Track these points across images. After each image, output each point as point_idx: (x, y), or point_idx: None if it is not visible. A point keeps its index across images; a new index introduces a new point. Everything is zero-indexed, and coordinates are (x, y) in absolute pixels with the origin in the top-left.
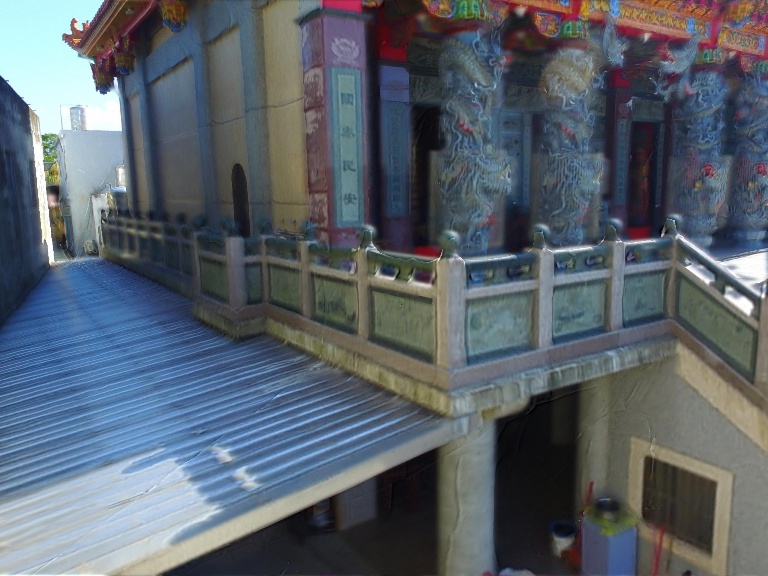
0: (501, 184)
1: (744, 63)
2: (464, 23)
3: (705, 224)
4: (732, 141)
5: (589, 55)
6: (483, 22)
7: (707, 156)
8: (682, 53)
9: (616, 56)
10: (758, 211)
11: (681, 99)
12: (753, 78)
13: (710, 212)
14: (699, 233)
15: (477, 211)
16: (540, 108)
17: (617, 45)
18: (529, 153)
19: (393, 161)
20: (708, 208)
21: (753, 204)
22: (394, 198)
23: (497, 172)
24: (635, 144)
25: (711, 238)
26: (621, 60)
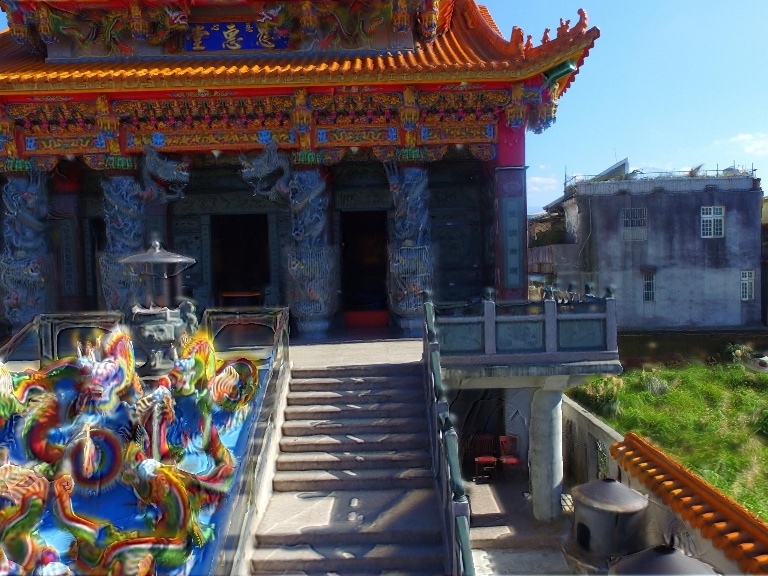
0: (24, 277)
1: (381, 154)
2: (5, 175)
3: (304, 310)
4: (487, 223)
5: (123, 180)
6: (16, 172)
7: (299, 247)
8: (259, 161)
9: (172, 174)
10: None
11: (285, 197)
12: None
13: (310, 299)
14: (297, 318)
15: (7, 295)
16: (217, 210)
17: (172, 166)
18: (209, 246)
19: (66, 258)
20: (308, 295)
21: (402, 292)
22: (67, 283)
23: (19, 269)
24: (349, 232)
25: (317, 324)
26: (183, 176)
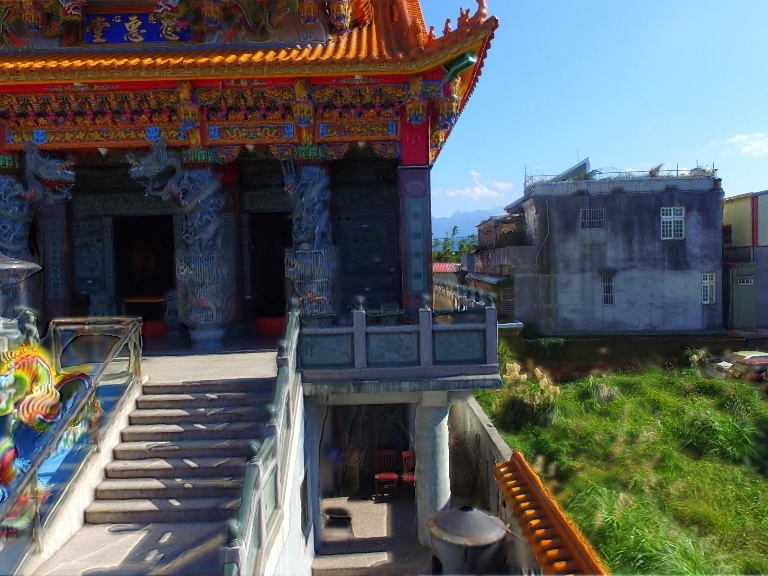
0: None
1: (278, 152)
2: None
3: (195, 318)
4: None
5: None
6: None
7: None
8: (148, 159)
9: (56, 173)
10: (299, 306)
11: (177, 198)
12: (282, 167)
13: (201, 306)
14: None
15: None
16: (120, 211)
17: (55, 164)
18: (111, 249)
19: None
20: (199, 302)
21: None
22: None
23: None
24: (259, 235)
25: (208, 332)
26: (67, 175)
